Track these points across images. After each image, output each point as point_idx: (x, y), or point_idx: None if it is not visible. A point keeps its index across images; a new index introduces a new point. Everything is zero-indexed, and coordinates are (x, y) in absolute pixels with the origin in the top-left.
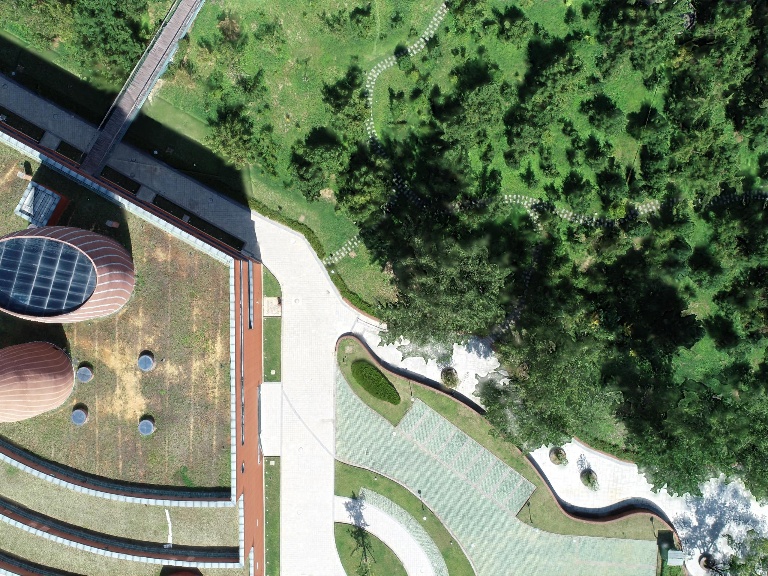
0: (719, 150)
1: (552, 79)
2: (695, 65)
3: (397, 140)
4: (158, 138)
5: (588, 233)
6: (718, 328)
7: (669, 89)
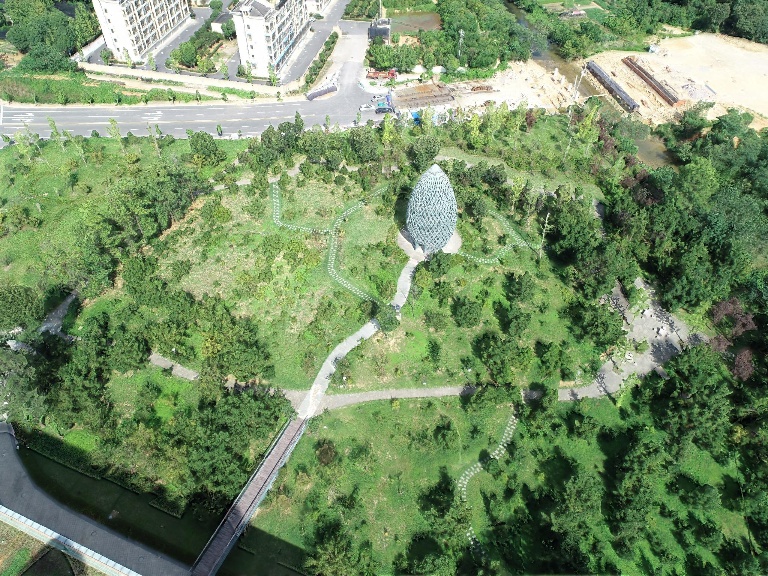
0: None
1: (637, 461)
2: (755, 438)
3: (500, 543)
4: (249, 570)
5: None
6: None
7: (740, 464)
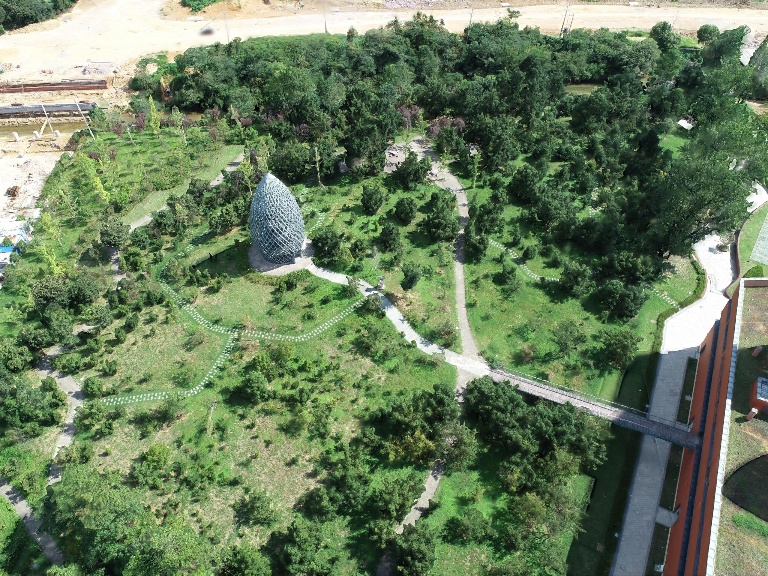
0: (551, 128)
1: (534, 177)
2: None
3: None
4: None
5: (603, 186)
6: (634, 143)
7: None
